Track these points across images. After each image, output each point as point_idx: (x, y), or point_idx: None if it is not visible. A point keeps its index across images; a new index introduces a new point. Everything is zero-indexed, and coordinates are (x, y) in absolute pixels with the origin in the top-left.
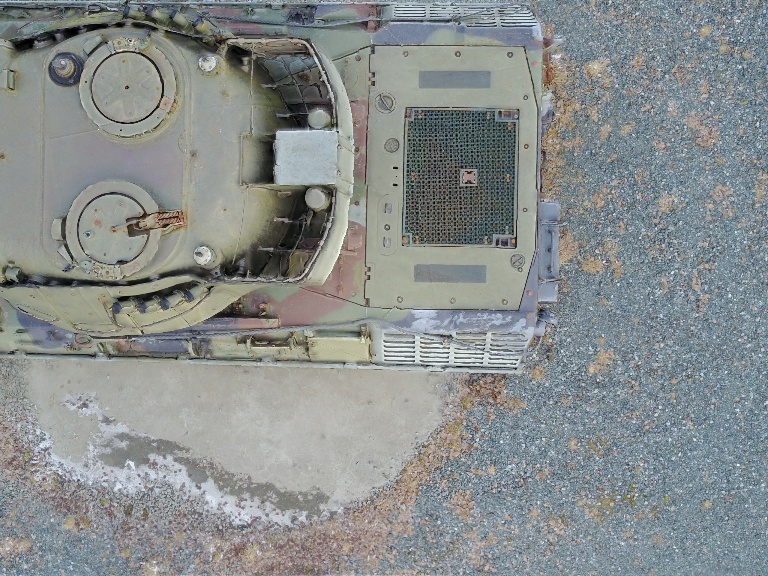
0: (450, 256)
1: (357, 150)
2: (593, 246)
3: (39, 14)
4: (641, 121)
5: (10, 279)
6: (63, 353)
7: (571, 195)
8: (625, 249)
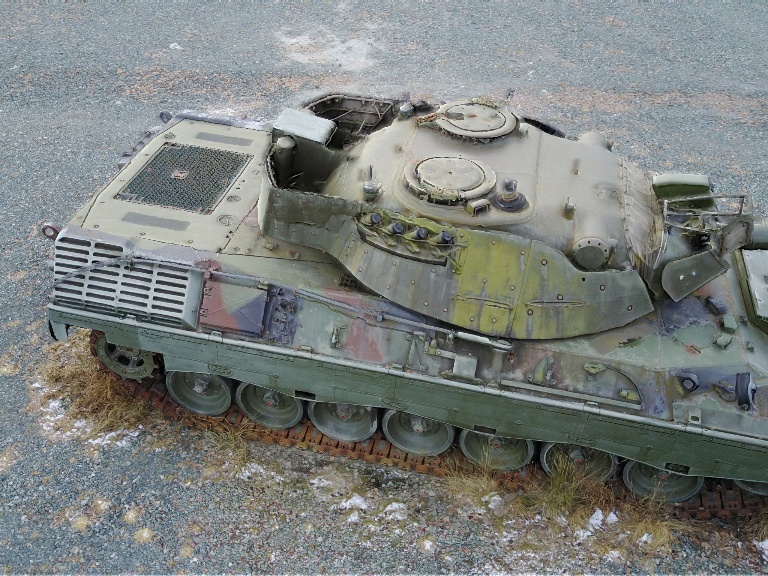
0: (220, 146)
1: None
2: None
3: (578, 378)
4: None
5: None
6: None
7: None
8: None
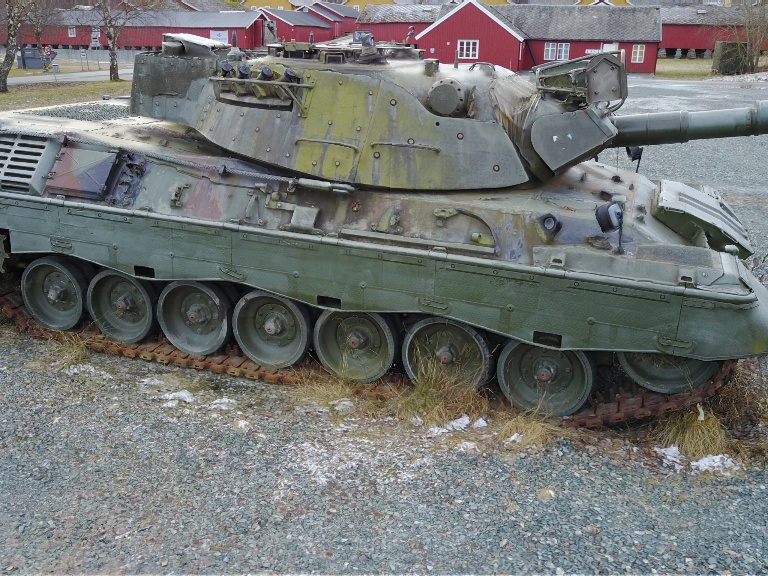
0: None
1: None
2: None
3: (427, 225)
4: None
5: None
6: None
7: None
8: None
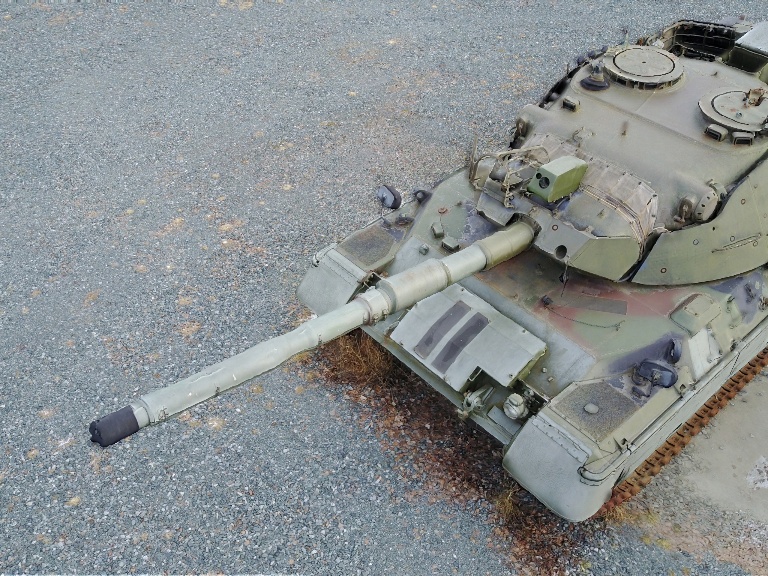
0: None
1: None
2: None
3: None
4: None
5: (720, 196)
6: (761, 320)
7: None
8: None
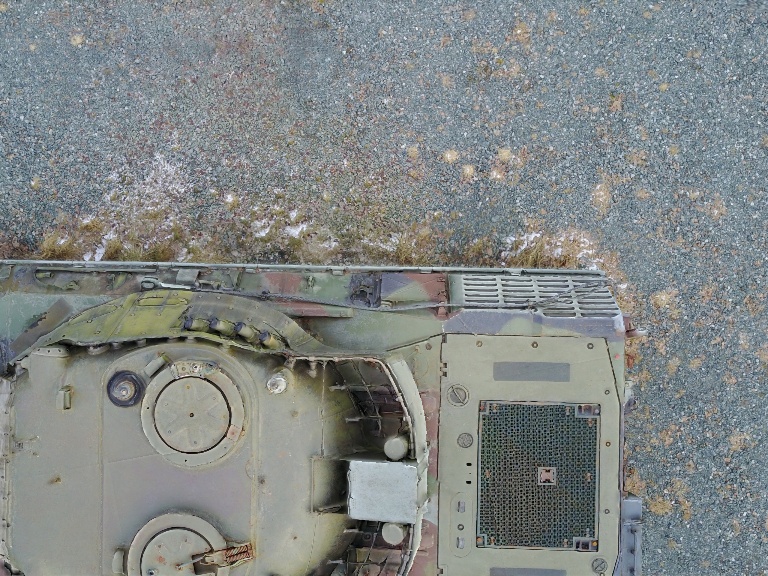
0: (527, 559)
1: (428, 444)
2: (661, 486)
3: (88, 281)
4: (711, 355)
5: None
6: None
7: (638, 432)
8: (695, 489)
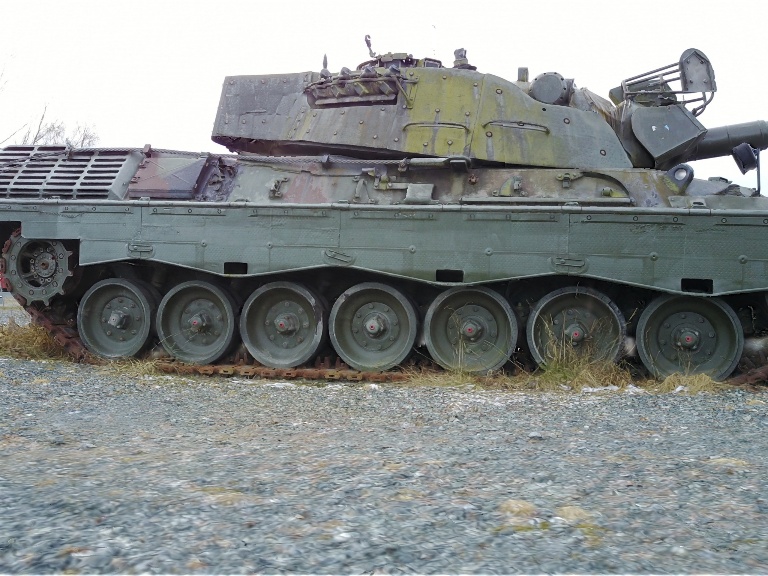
0: None
1: None
2: None
3: (552, 189)
4: None
5: None
6: None
7: None
8: None
